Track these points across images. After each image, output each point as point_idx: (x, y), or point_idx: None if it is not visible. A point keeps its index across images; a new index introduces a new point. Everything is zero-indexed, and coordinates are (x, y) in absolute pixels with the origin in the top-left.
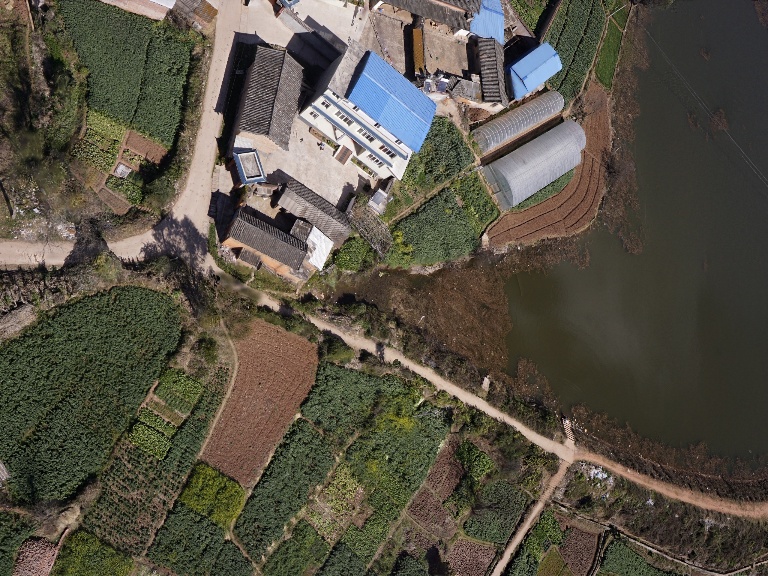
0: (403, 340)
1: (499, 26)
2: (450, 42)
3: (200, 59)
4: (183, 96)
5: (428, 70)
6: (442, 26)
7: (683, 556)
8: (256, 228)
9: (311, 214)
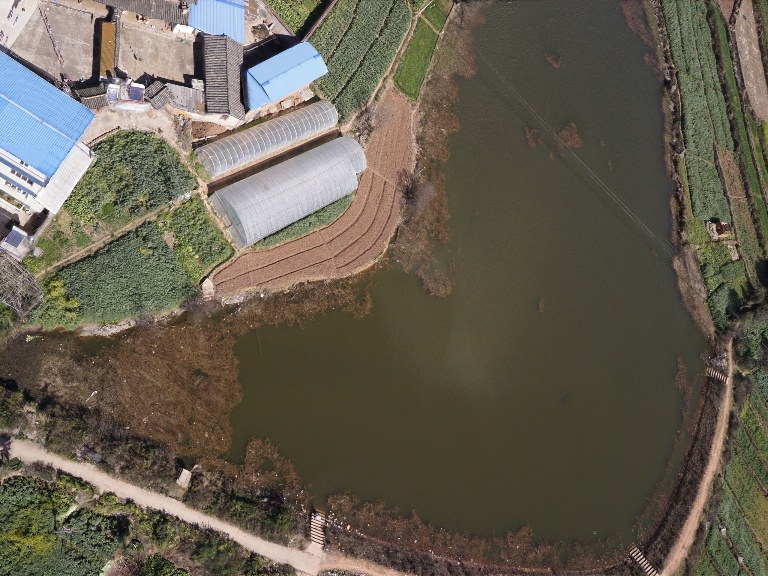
0: (46, 428)
1: (236, 21)
2: (168, 40)
3: None
4: None
5: (129, 74)
6: (155, 20)
7: None
8: None
9: None
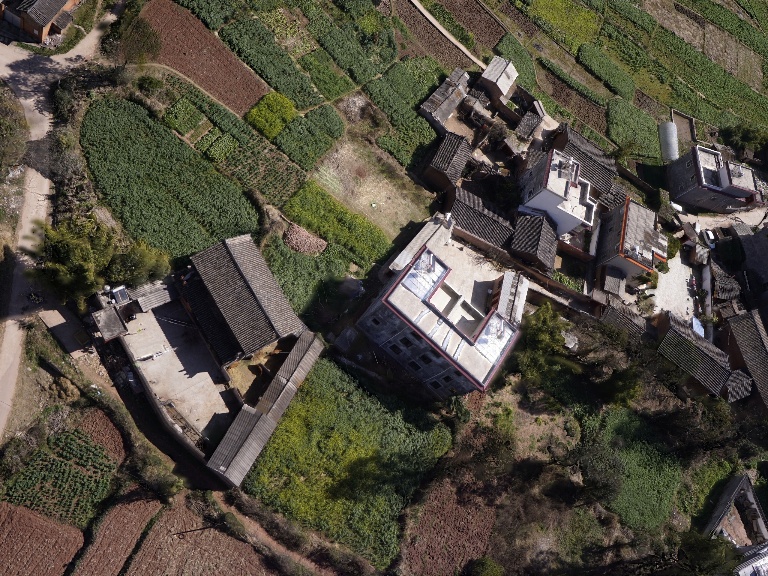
0: None
1: None
2: None
3: None
4: None
5: None
6: None
7: None
8: None
9: None
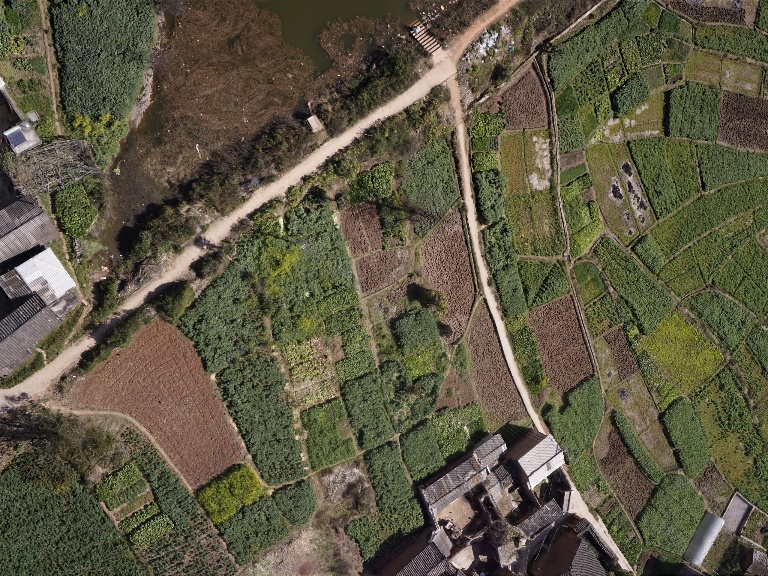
0: (208, 207)
1: None
2: None
3: None
4: None
5: None
6: None
7: None
8: None
9: None
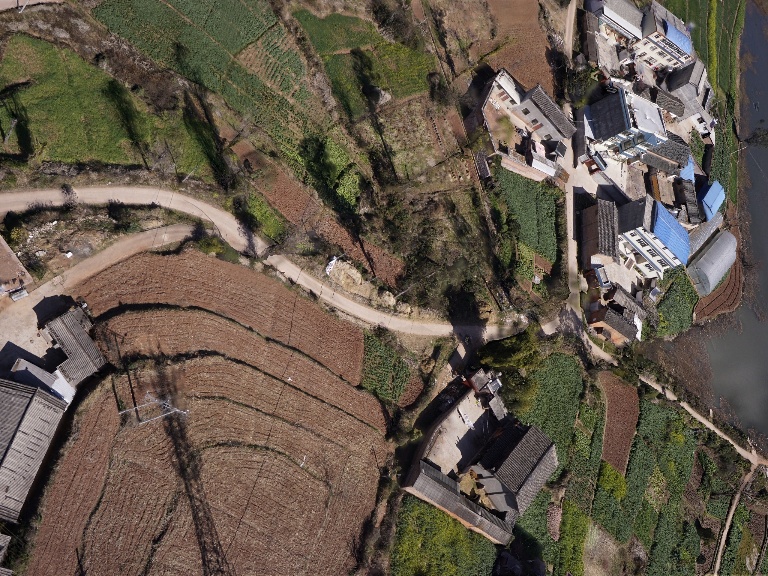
0: (673, 384)
1: (692, 171)
2: (665, 182)
3: (564, 206)
4: (555, 230)
5: None
6: (661, 172)
7: None
8: (616, 316)
9: (629, 305)
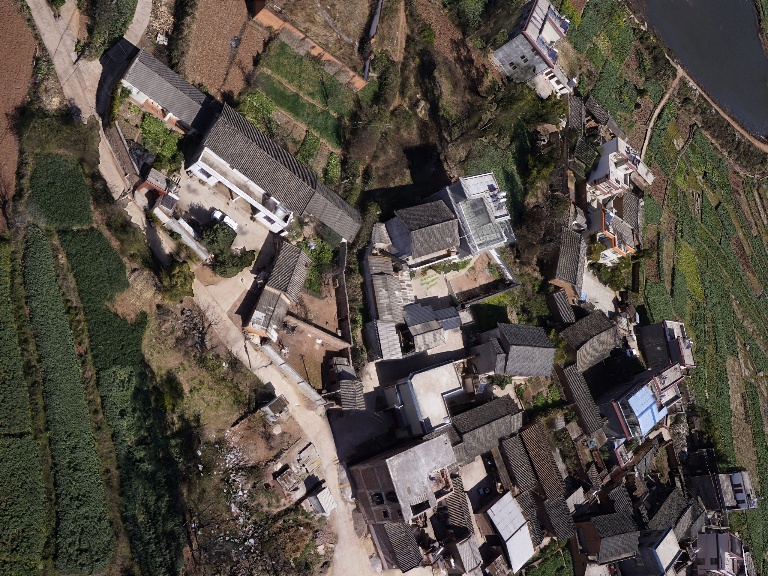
0: None
1: None
2: None
3: None
4: None
5: None
6: None
7: (725, 153)
8: None
9: None
